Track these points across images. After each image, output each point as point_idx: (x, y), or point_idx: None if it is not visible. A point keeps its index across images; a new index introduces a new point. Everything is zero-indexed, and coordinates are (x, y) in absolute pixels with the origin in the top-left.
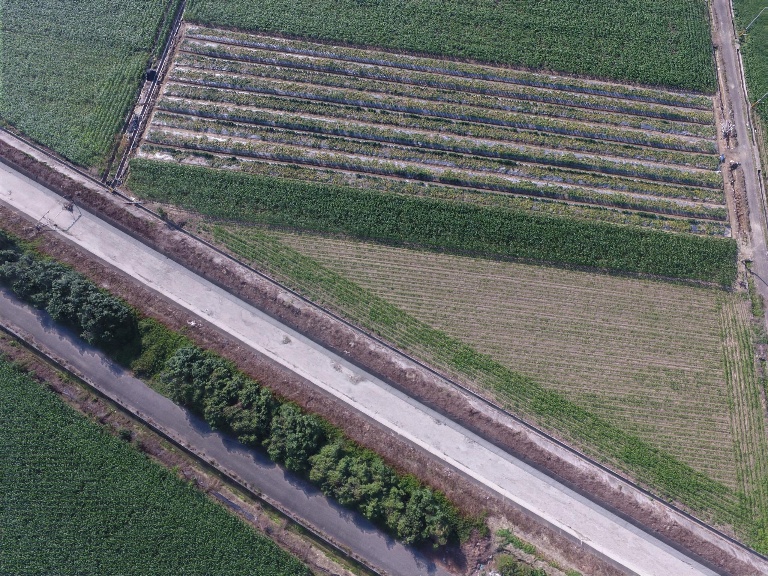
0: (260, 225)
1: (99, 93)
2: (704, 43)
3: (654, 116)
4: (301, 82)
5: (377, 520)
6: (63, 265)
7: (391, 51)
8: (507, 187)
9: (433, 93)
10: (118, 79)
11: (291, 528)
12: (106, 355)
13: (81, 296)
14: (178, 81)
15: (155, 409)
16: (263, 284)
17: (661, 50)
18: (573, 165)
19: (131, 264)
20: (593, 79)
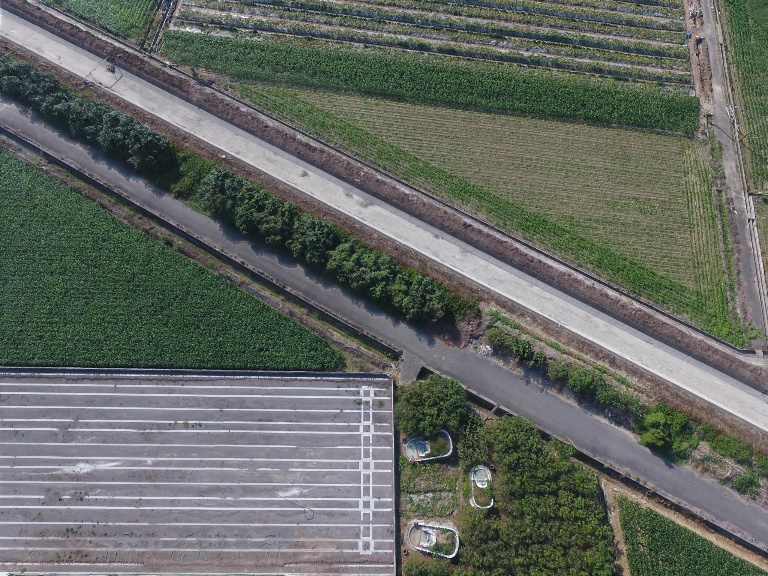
0: (280, 84)
1: None
2: None
3: (629, 1)
4: None
5: (385, 306)
6: None
7: None
8: (497, 56)
9: None
10: None
11: (311, 316)
12: (149, 181)
13: (128, 125)
14: None
15: (193, 223)
16: (283, 128)
17: None
18: (556, 39)
19: (167, 114)
20: None
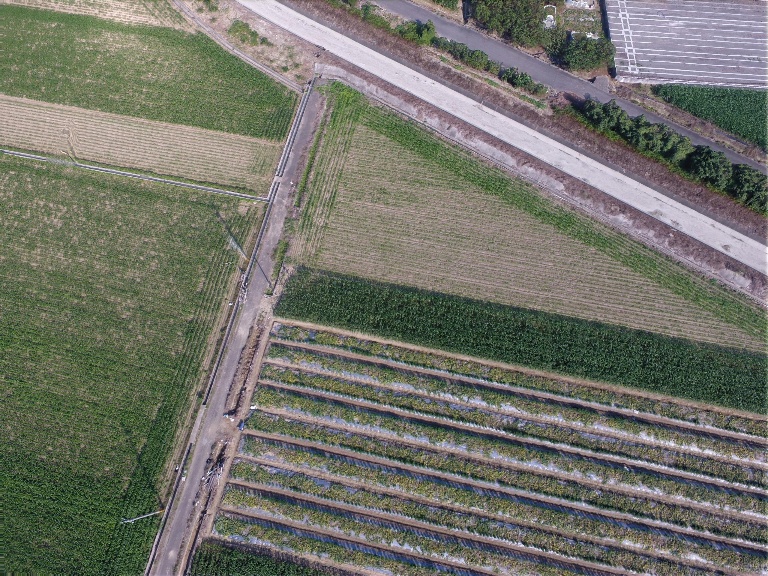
0: None
1: None
2: None
3: (306, 503)
4: None
5: None
6: None
7: None
8: (518, 397)
9: (616, 559)
10: None
11: None
12: None
13: None
14: None
15: None
16: None
17: None
18: (433, 426)
19: None
20: None
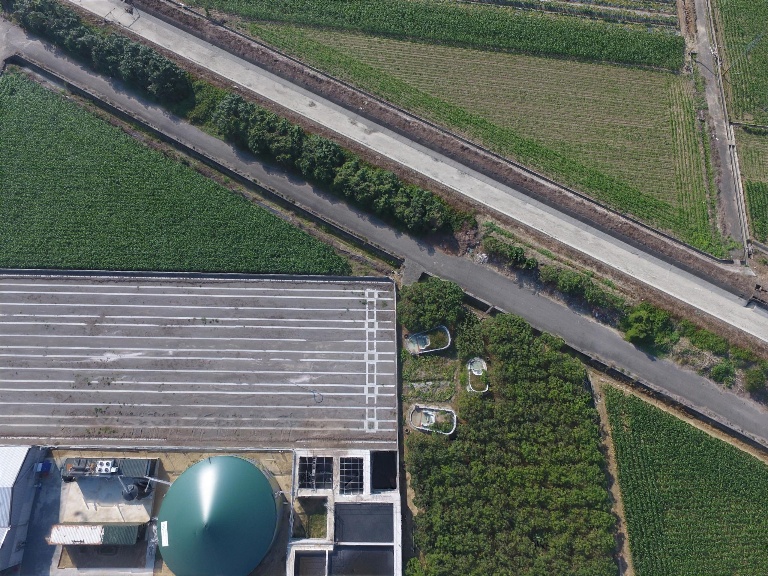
0: (288, 24)
1: None
2: None
3: None
4: None
5: (388, 219)
6: None
7: None
8: None
9: None
10: None
11: (319, 229)
12: (167, 109)
13: (148, 54)
14: None
15: (208, 146)
16: (292, 63)
17: None
18: None
19: (183, 51)
20: None
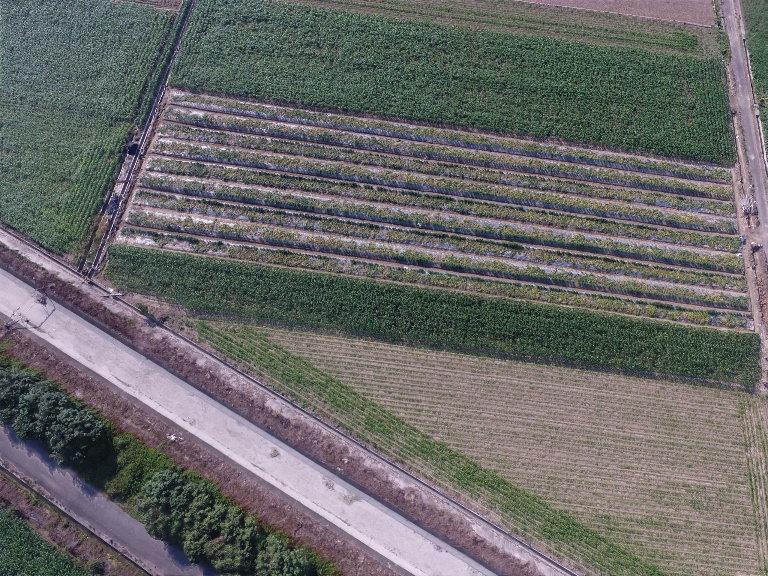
0: (247, 320)
1: (77, 170)
2: (722, 109)
3: (669, 191)
4: (293, 155)
5: None
6: (33, 371)
7: (389, 119)
8: (513, 274)
9: (434, 167)
10: (97, 154)
11: None
12: (78, 474)
13: (50, 414)
14: (162, 154)
15: (130, 537)
16: (250, 389)
17: (676, 117)
18: (583, 248)
19: (108, 365)
20: (604, 149)
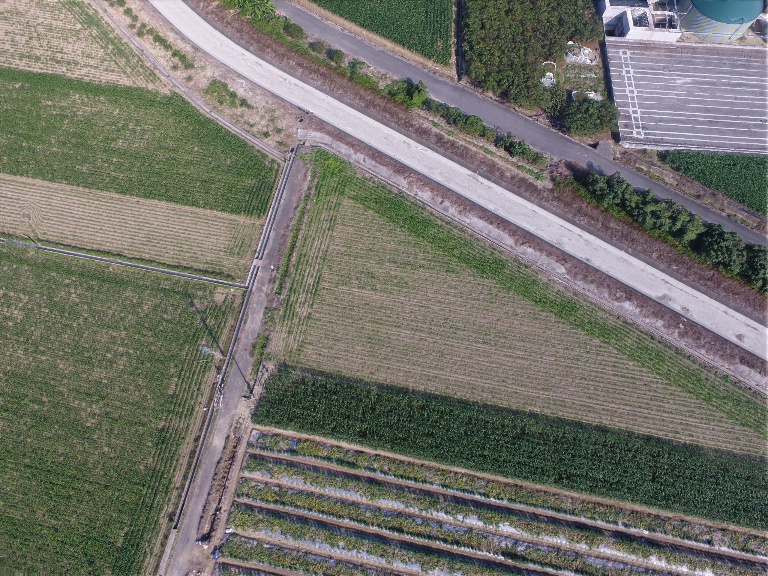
0: None
1: None
2: None
3: None
4: None
5: None
6: None
7: None
8: (517, 516)
9: None
10: None
11: None
12: None
13: None
14: None
15: None
16: None
17: None
18: (425, 551)
19: None
20: None
